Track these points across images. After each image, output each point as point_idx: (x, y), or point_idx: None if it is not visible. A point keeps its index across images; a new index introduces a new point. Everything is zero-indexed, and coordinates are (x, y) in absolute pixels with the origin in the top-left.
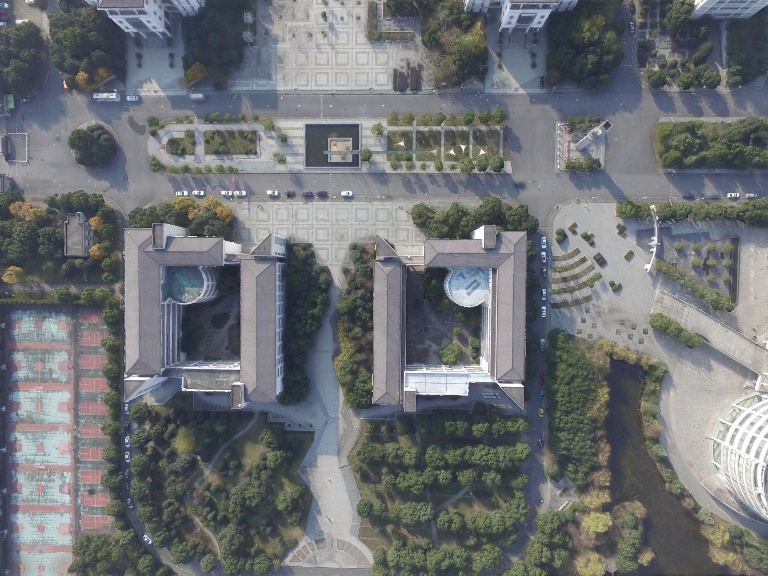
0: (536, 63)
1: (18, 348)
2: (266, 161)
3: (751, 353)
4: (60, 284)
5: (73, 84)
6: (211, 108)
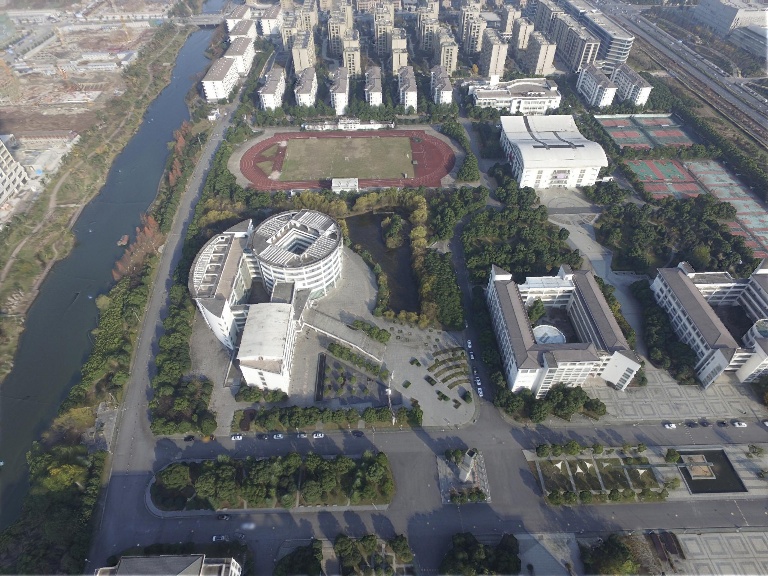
0: (528, 571)
1: None
2: (765, 454)
3: (316, 320)
4: None
5: None
6: None
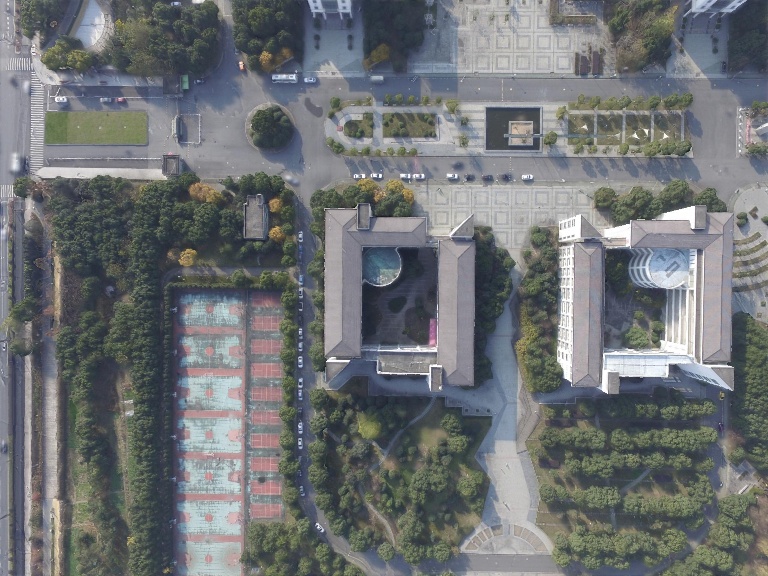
0: (718, 48)
1: (187, 333)
2: (445, 144)
3: None
4: (232, 268)
5: (256, 64)
6: (390, 90)
